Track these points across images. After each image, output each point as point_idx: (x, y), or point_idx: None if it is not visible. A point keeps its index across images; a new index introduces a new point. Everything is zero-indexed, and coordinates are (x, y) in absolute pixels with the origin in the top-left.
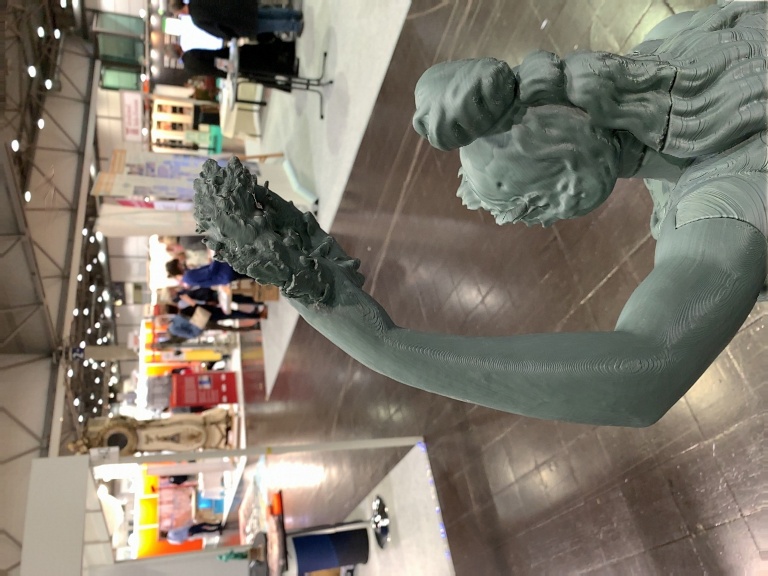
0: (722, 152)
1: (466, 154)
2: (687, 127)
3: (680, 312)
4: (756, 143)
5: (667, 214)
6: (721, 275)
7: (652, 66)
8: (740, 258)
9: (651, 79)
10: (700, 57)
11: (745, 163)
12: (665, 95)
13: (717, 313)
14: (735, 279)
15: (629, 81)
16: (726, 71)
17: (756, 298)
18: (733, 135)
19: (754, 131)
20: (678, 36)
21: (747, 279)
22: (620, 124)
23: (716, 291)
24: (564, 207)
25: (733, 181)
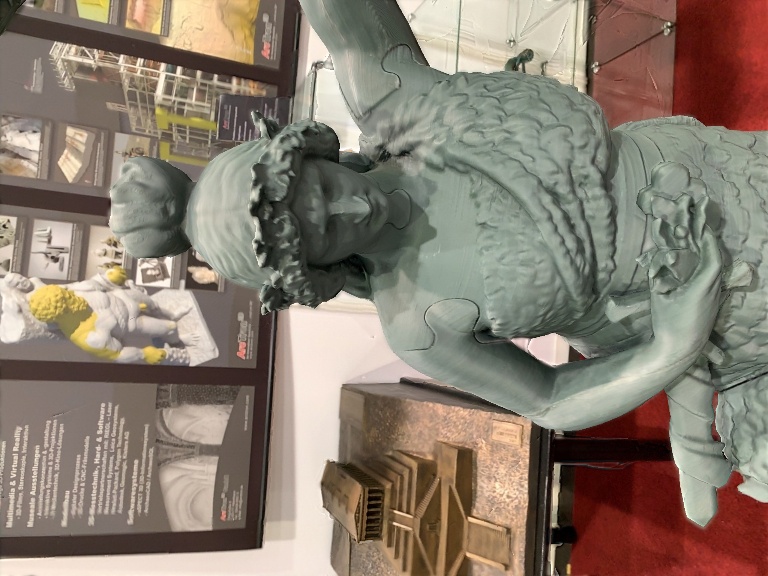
0: None
1: (196, 190)
2: None
3: None
4: None
5: (356, 110)
6: None
7: None
8: None
9: None
10: None
11: None
12: None
13: None
14: None
15: None
16: None
17: None
18: None
19: None
20: None
21: None
22: None
23: None
24: None
25: None
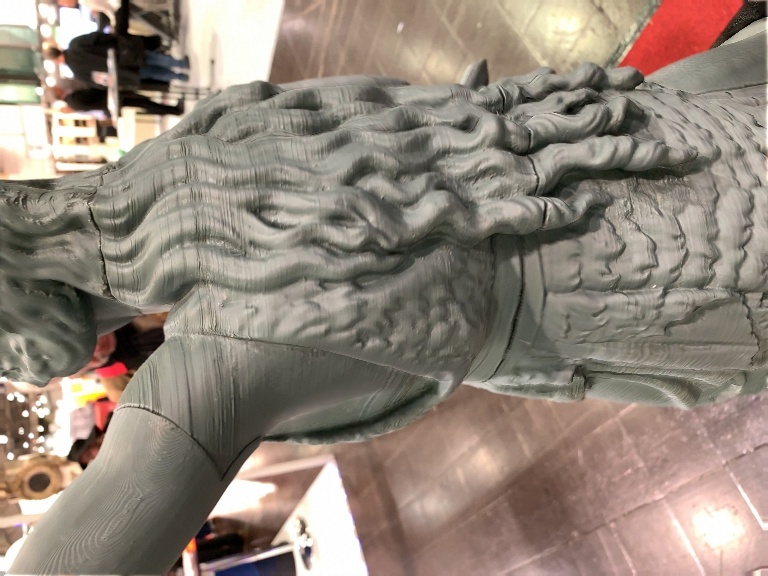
0: (175, 304)
1: None
2: (123, 276)
3: (44, 565)
4: (194, 297)
5: None
6: (119, 497)
7: (61, 201)
8: (149, 468)
9: (61, 219)
10: (137, 181)
11: (184, 324)
12: (94, 234)
13: (104, 556)
14: (139, 500)
15: (29, 224)
16: (155, 202)
17: (198, 508)
18: (166, 288)
19: (188, 282)
20: (150, 143)
21: (159, 496)
22: (45, 275)
23: (105, 524)
24: (31, 372)
25: (173, 348)
